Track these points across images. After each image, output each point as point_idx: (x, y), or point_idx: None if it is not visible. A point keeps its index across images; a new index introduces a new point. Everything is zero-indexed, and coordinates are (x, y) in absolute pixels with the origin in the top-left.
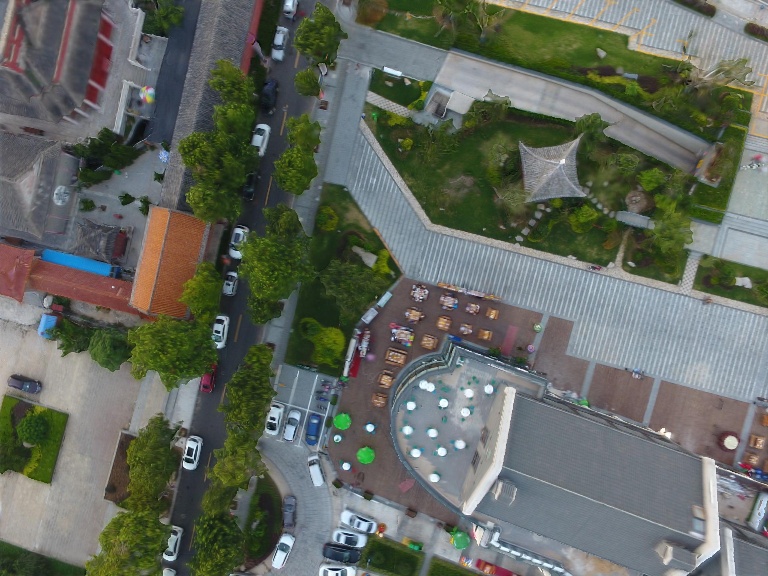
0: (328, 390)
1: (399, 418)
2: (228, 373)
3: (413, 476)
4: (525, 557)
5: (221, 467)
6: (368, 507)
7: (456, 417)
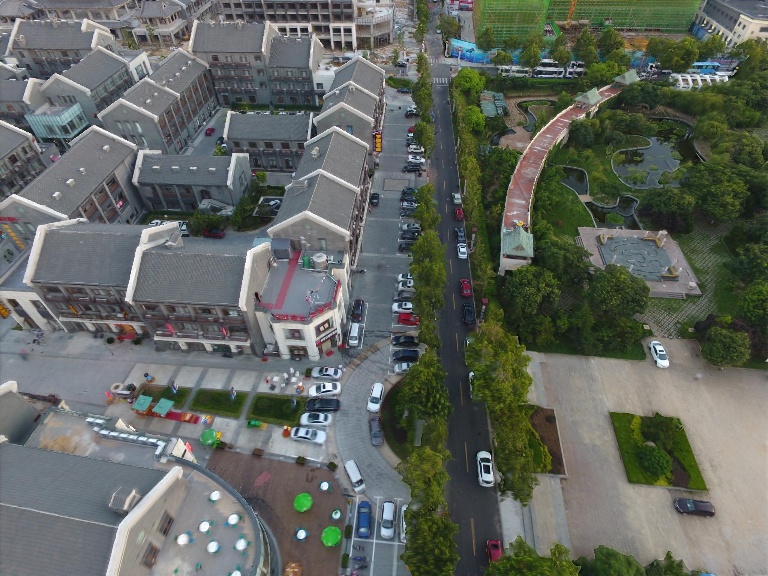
0: (354, 572)
1: (252, 558)
2: (476, 570)
3: (254, 490)
4: (134, 437)
5: (435, 464)
6: (301, 450)
7: (185, 573)
